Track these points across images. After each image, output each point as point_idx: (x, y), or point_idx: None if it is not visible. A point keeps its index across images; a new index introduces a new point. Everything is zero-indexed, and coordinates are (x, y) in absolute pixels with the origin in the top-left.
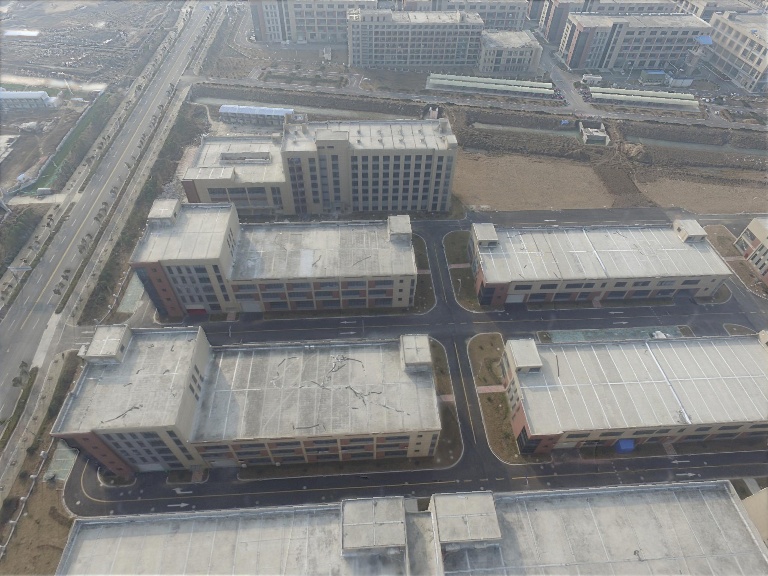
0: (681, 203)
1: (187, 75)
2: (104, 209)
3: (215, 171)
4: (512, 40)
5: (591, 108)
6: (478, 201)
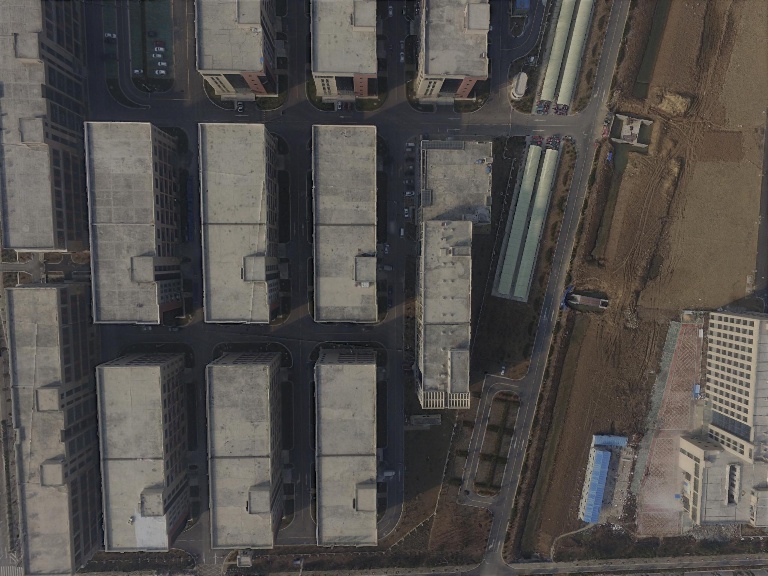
0: (762, 103)
1: (481, 575)
2: (740, 574)
3: (762, 505)
4: (463, 178)
5: (583, 114)
6: (741, 284)
